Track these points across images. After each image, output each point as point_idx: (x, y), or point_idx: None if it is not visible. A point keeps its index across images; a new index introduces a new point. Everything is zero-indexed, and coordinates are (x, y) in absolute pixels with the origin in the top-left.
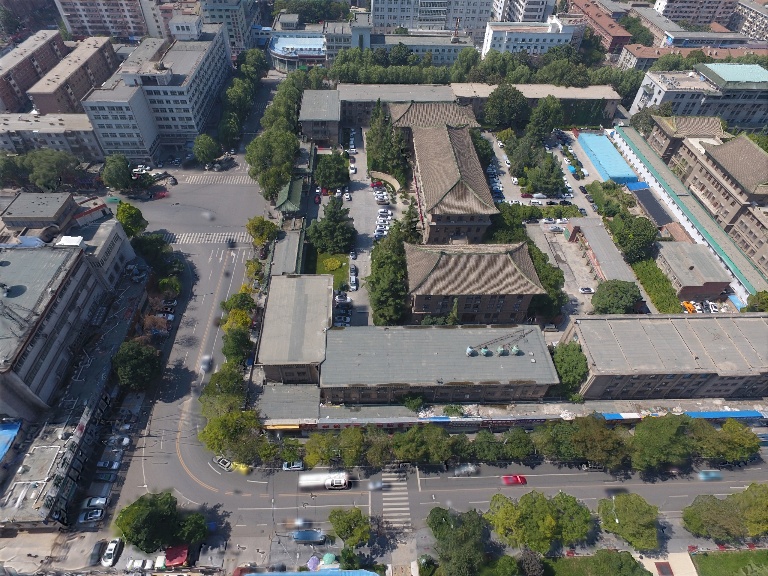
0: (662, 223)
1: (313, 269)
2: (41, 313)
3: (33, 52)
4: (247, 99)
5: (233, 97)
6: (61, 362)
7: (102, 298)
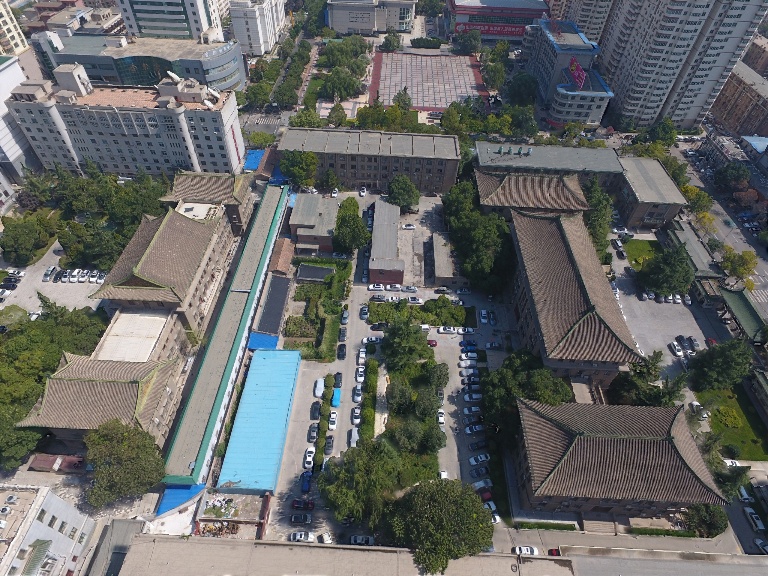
0: (285, 280)
1: None
2: None
3: None
4: None
5: None
6: None
7: None
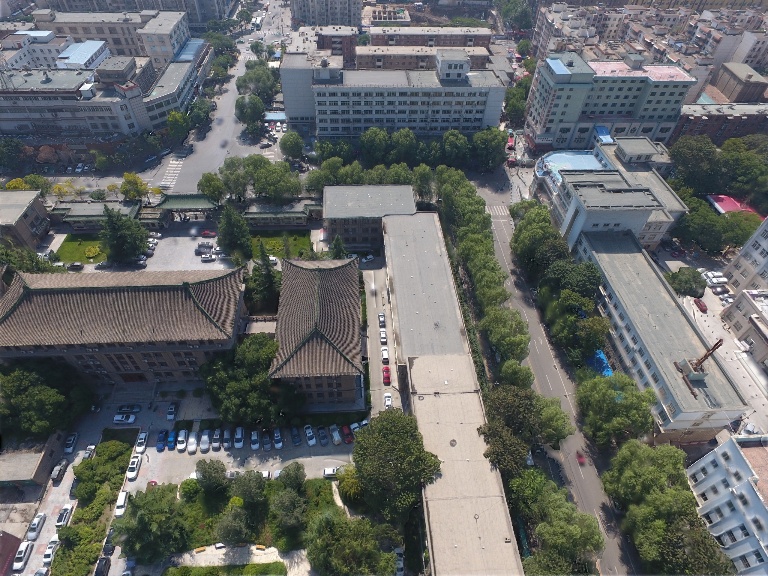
0: None
1: (93, 238)
2: (15, 91)
3: (439, 35)
4: (392, 152)
5: (367, 135)
6: (26, 125)
7: (87, 130)
